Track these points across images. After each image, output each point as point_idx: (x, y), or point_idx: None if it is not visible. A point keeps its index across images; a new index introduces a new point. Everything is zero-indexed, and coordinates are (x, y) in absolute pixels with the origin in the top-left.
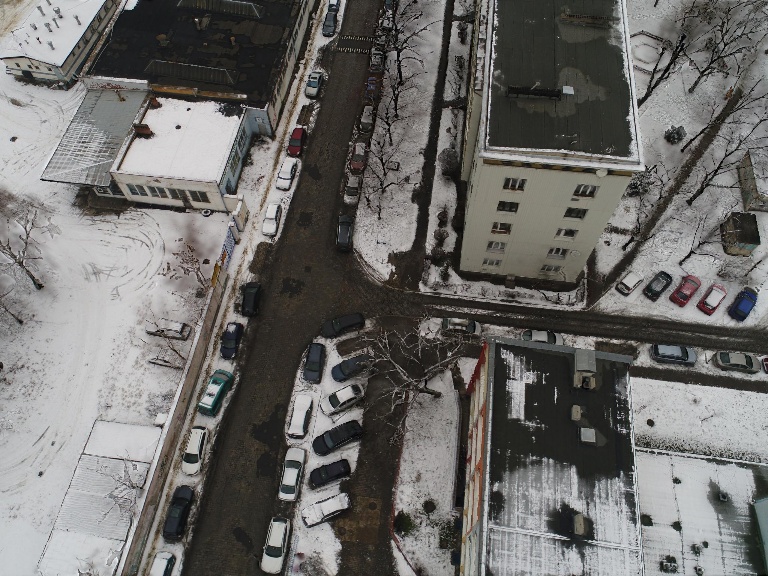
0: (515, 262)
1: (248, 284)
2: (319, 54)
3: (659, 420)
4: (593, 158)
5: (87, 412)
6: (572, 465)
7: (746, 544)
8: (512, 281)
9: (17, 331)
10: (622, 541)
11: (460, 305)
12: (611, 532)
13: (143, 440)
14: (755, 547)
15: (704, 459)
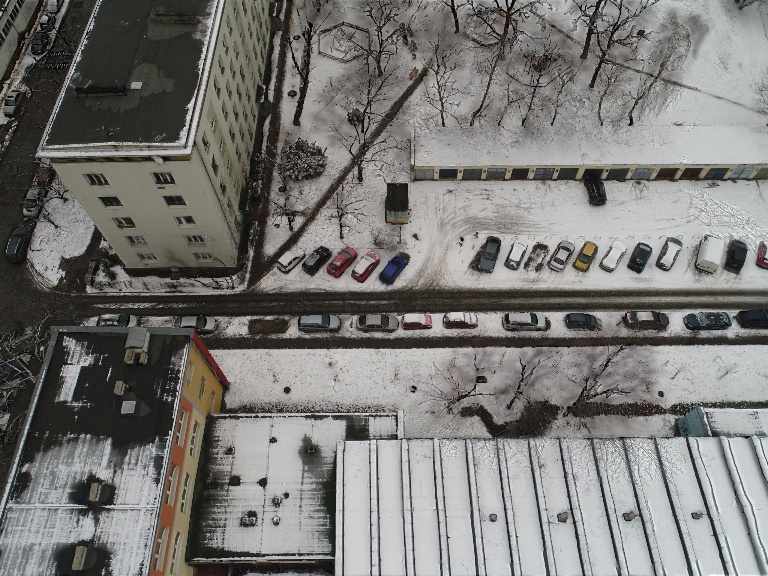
0: (166, 254)
1: None
2: (25, 73)
3: (295, 386)
4: (142, 147)
5: None
6: (108, 437)
7: (324, 490)
8: (178, 272)
9: None
10: (140, 502)
11: (124, 301)
12: (131, 495)
13: None
14: (332, 491)
15: (303, 416)
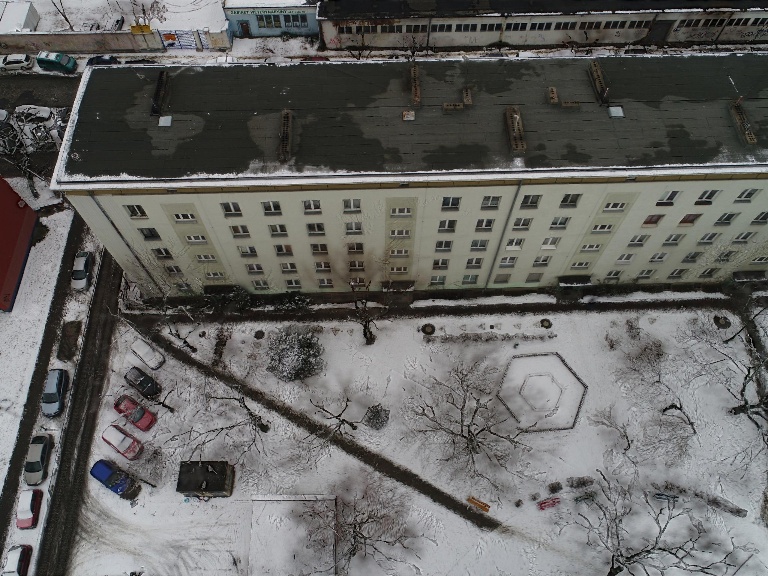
0: None
1: (153, 62)
2: None
3: None
4: None
5: (54, 6)
6: None
7: None
8: None
9: None
10: None
11: None
12: None
13: (13, 27)
14: None
15: None
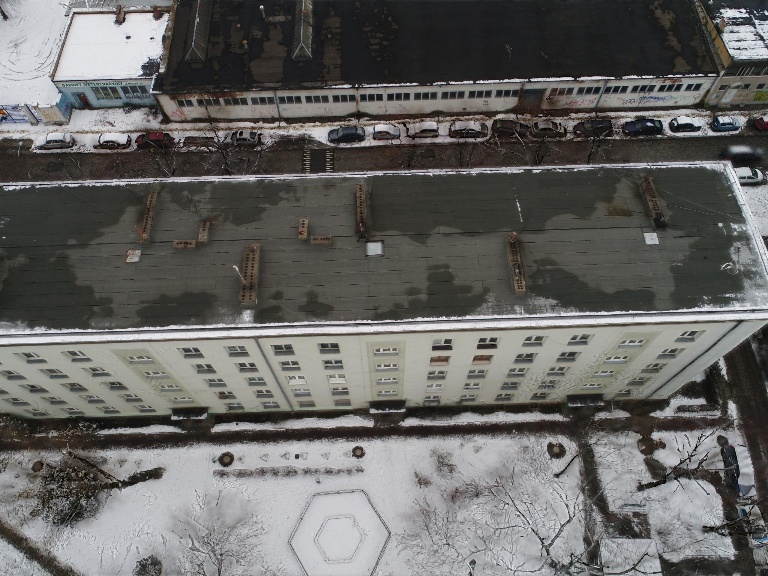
0: None
1: None
2: (298, 136)
3: None
4: None
5: None
6: None
7: None
8: None
9: None
10: None
11: None
12: None
13: None
14: None
15: None
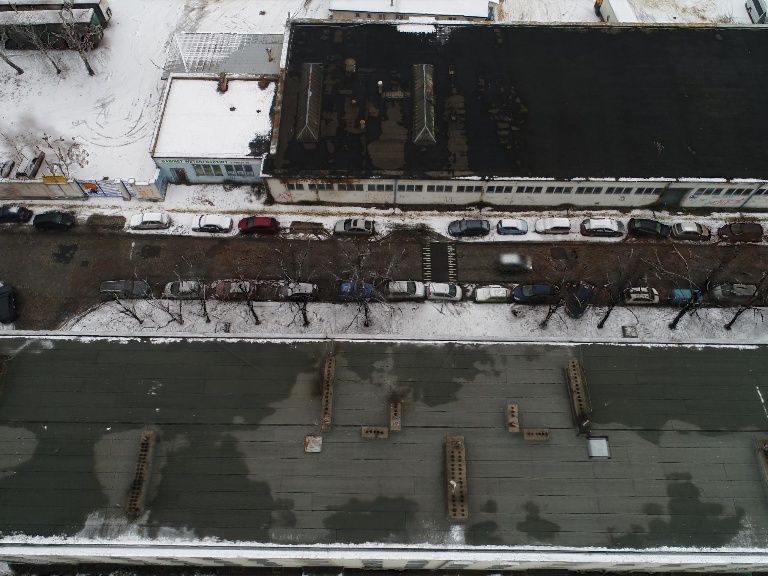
0: None
1: (69, 215)
2: (414, 226)
3: None
4: None
5: None
6: None
7: None
8: None
9: (51, 73)
10: None
11: None
12: None
13: None
14: None
15: None
